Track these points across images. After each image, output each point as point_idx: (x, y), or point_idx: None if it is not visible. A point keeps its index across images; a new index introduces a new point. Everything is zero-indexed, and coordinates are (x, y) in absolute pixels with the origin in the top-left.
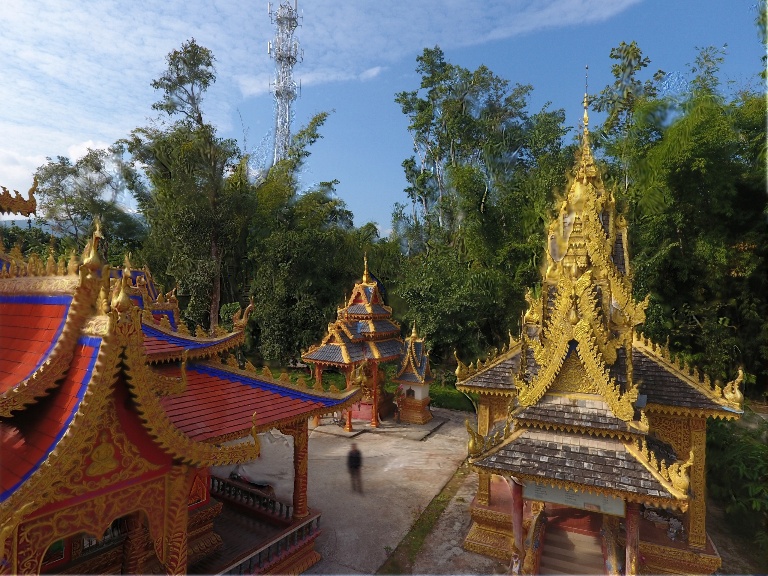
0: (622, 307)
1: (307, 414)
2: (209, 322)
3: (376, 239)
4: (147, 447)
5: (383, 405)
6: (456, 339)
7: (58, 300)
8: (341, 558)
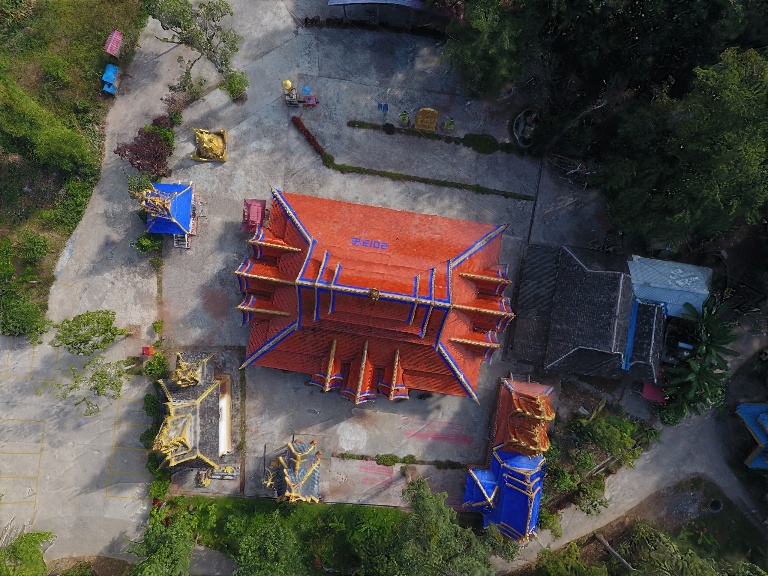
0: None
1: None
2: None
3: None
4: None
5: None
6: None
7: None
8: None
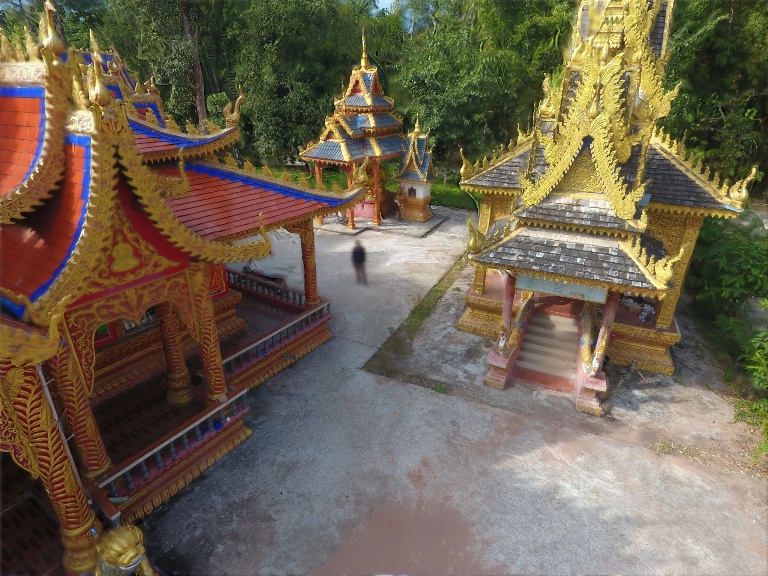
0: (647, 98)
1: (312, 214)
2: (197, 116)
3: (374, 11)
4: (163, 246)
5: (385, 204)
6: (461, 134)
7: (29, 92)
8: (350, 336)
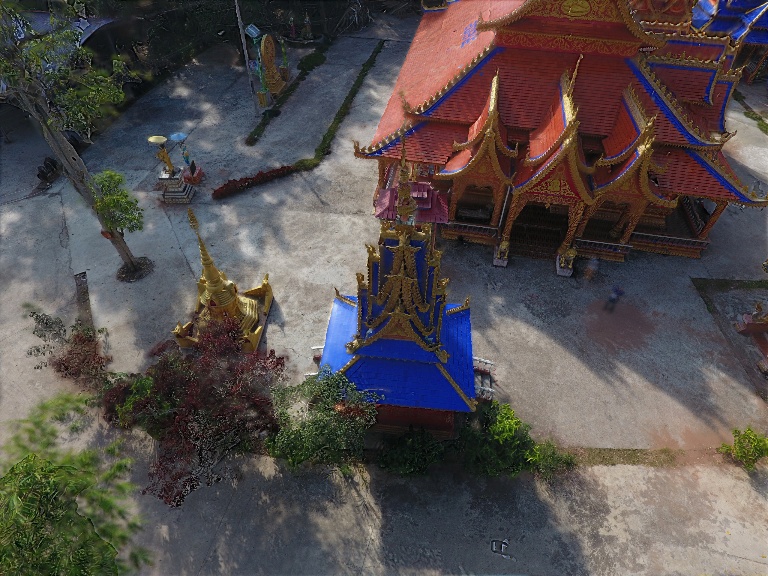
0: None
1: (725, 199)
2: None
3: None
4: None
5: None
6: None
7: None
8: (708, 264)
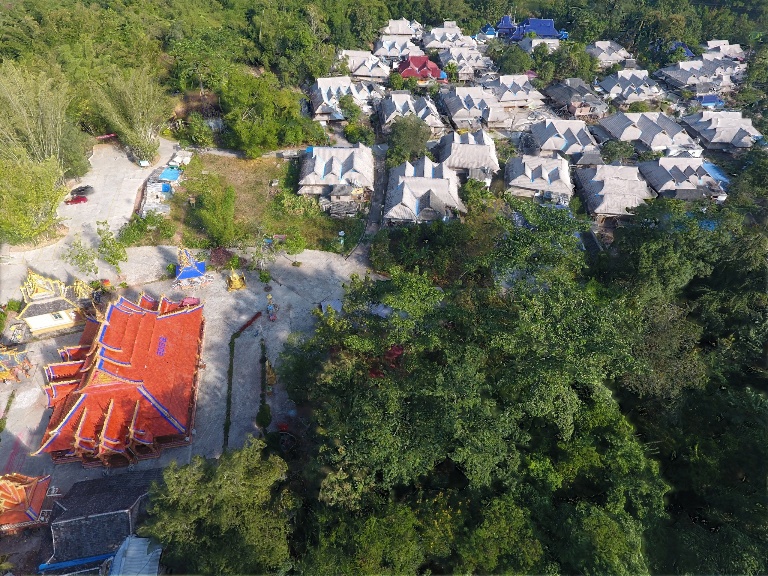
0: None
1: None
2: None
3: None
4: None
5: None
6: None
7: None
8: None
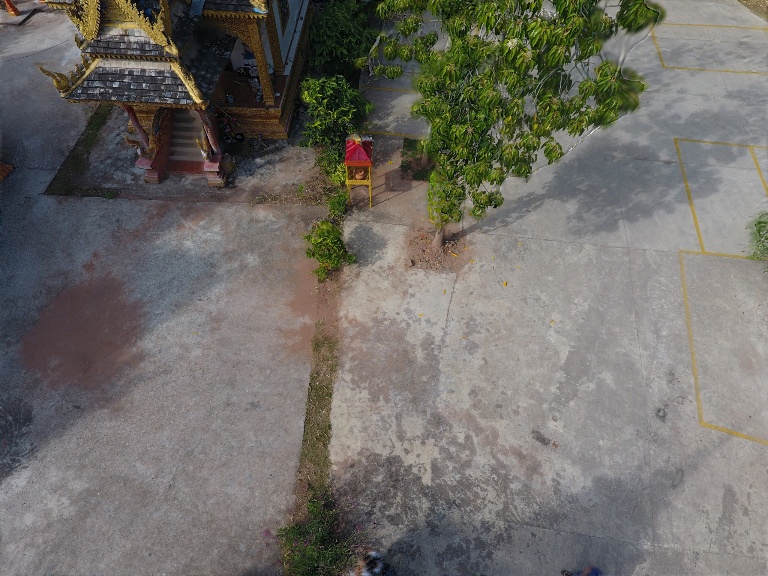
0: None
1: None
2: None
3: None
4: None
5: None
6: None
7: None
8: (30, 163)
